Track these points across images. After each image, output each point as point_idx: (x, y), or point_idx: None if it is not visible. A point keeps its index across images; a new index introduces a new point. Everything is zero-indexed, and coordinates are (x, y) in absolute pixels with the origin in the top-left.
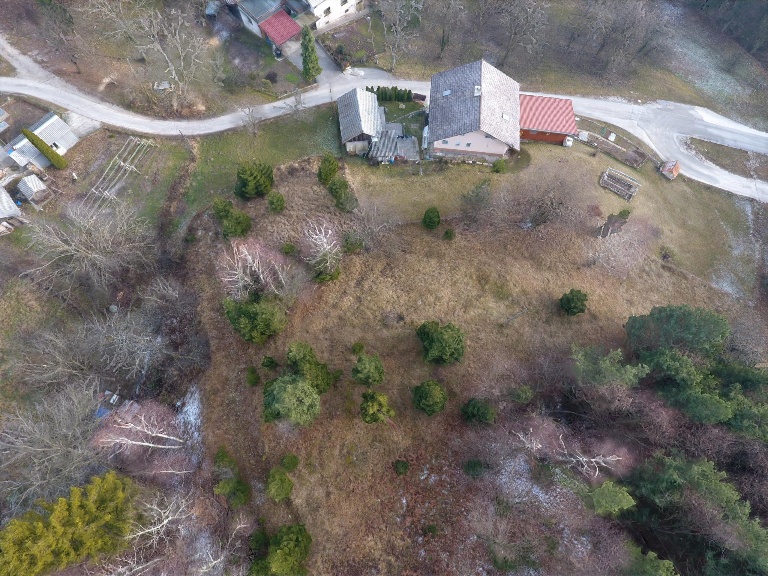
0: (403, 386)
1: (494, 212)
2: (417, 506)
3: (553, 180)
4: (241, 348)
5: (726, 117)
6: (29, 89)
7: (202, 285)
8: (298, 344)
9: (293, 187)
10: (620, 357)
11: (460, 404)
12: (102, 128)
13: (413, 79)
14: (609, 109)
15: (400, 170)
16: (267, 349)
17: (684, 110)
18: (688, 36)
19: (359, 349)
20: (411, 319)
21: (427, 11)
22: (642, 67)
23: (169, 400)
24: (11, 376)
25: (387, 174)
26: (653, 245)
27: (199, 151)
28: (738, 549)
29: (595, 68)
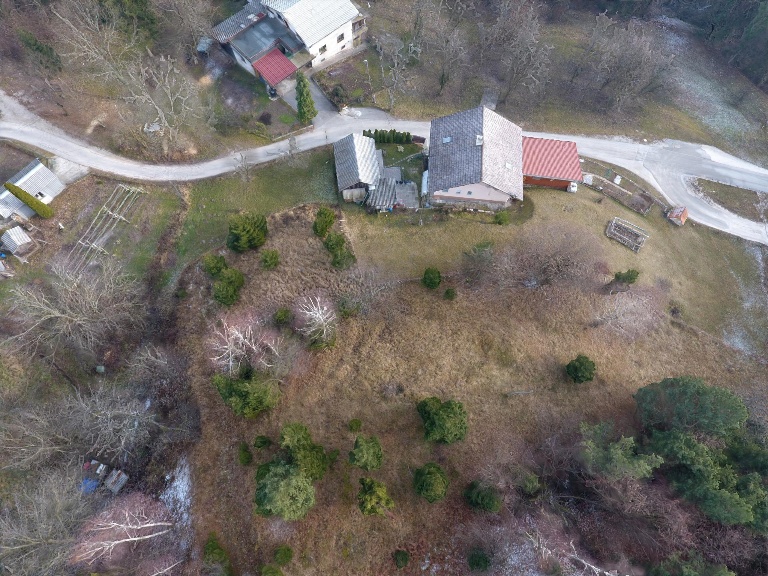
0: (403, 466)
1: None
2: None
3: (558, 232)
4: (233, 418)
5: (734, 156)
6: (14, 133)
7: (193, 346)
8: (292, 425)
9: (288, 239)
10: (632, 444)
11: (463, 484)
12: (90, 174)
13: (412, 119)
14: (614, 149)
15: (399, 219)
16: (260, 424)
17: (691, 149)
18: (694, 68)
19: (356, 427)
20: (411, 391)
21: (426, 44)
22: (647, 103)
23: (158, 471)
24: None
25: (385, 223)
26: (662, 299)
27: (190, 198)
28: None
29: (599, 105)
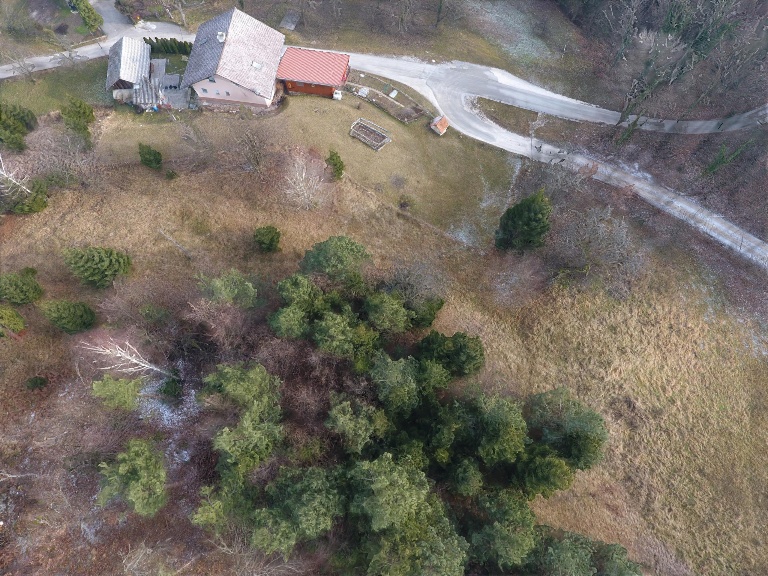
0: None
1: (225, 155)
2: (43, 420)
3: (295, 127)
4: None
5: (523, 79)
6: None
7: None
8: None
9: (49, 130)
10: (241, 278)
11: None
12: None
13: None
14: (400, 68)
15: (162, 118)
16: None
17: (479, 71)
18: (513, 3)
19: (26, 273)
20: None
21: None
22: (450, 30)
23: None
24: None
25: (147, 121)
26: (393, 194)
27: None
28: None
29: None
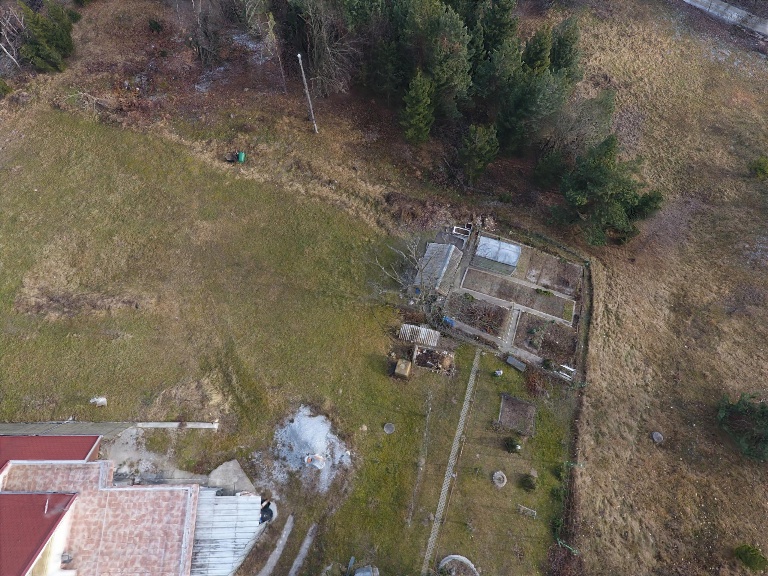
0: None
1: None
2: None
3: None
4: None
5: None
6: None
7: None
8: None
9: None
10: None
11: None
12: None
13: None
14: None
15: None
16: None
17: None
18: None
19: None
20: None
21: None
22: None
23: None
24: None
25: None
26: None
27: None
28: None
29: None
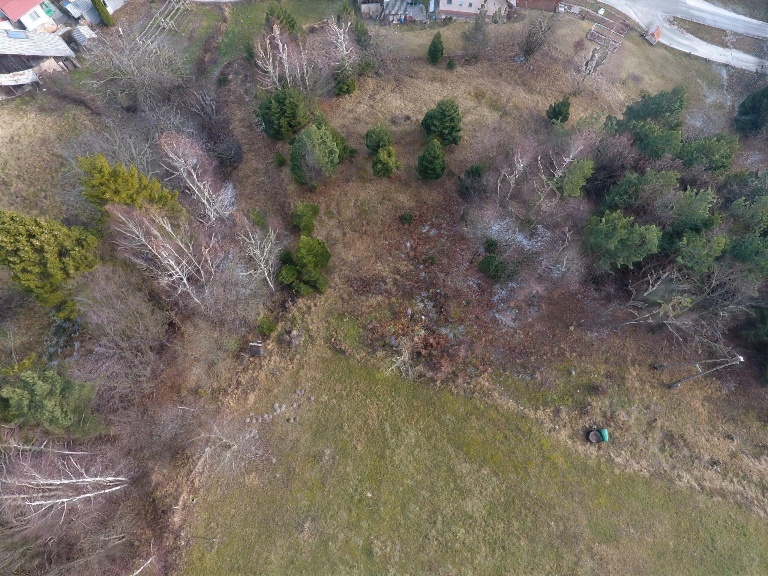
0: (409, 166)
1: (491, 51)
2: None
3: None
4: (269, 150)
5: (708, 2)
6: None
7: (234, 111)
8: None
9: (314, 38)
10: None
11: (458, 182)
12: None
13: None
14: None
15: (409, 28)
16: None
17: None
18: None
19: None
20: (417, 118)
21: None
22: None
23: None
24: (69, 177)
25: (397, 30)
26: (634, 88)
27: (230, 14)
28: (679, 217)
29: None
